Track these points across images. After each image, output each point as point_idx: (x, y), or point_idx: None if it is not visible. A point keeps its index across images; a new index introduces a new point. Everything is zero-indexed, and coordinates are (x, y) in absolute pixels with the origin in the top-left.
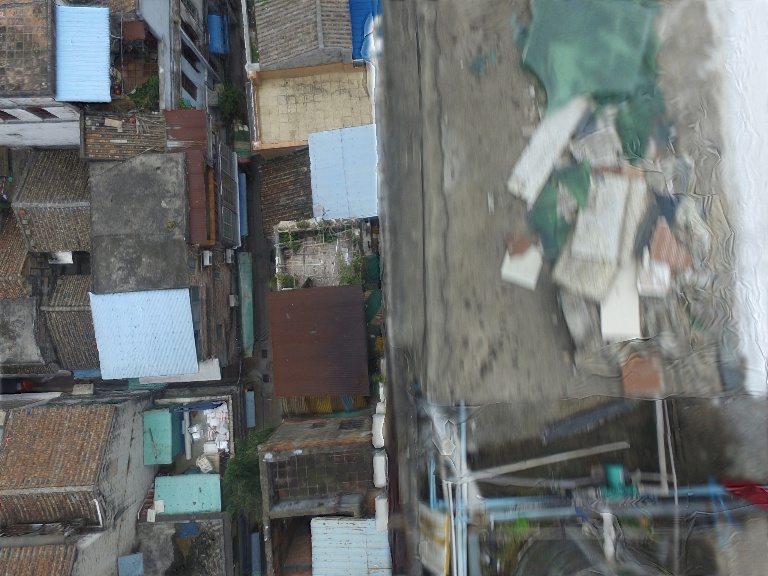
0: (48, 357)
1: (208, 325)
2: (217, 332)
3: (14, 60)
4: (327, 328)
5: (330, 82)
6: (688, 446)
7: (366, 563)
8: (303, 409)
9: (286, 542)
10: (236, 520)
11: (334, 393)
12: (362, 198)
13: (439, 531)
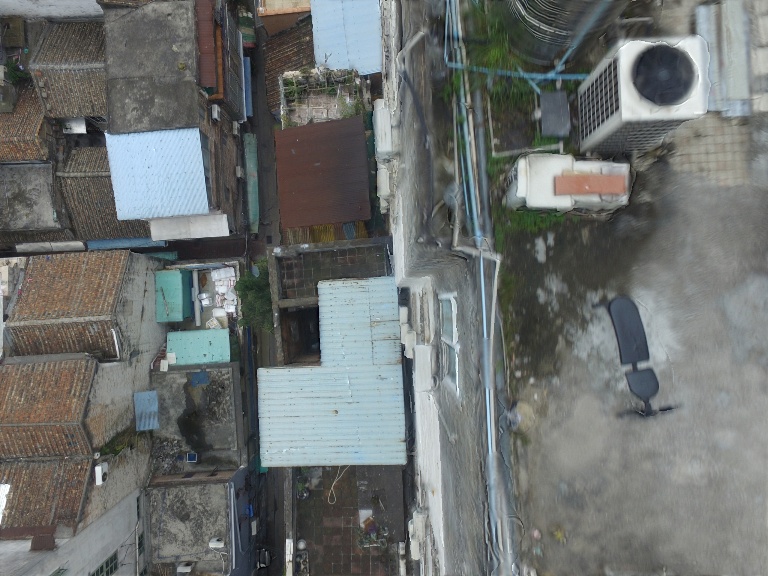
0: (64, 223)
1: (217, 178)
2: (225, 192)
3: None
4: (330, 159)
5: None
6: None
7: (369, 317)
8: None
9: (294, 349)
10: (244, 378)
11: (337, 220)
12: (362, 56)
13: None
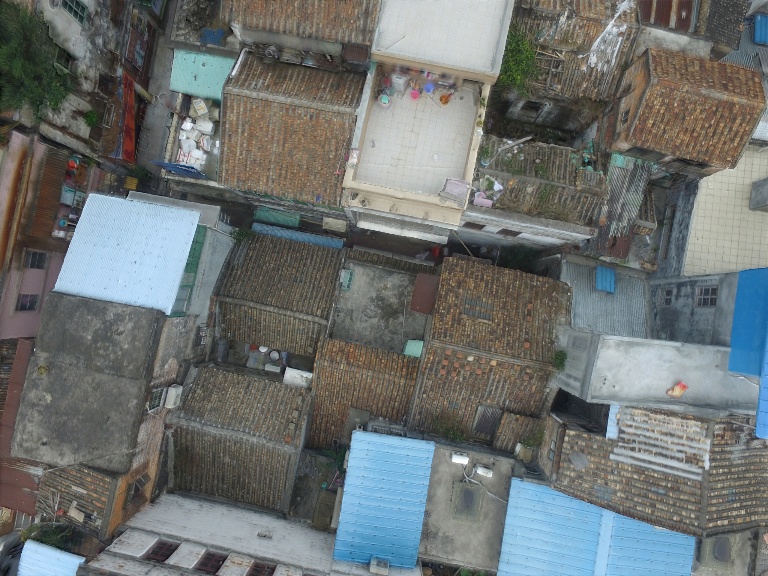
0: None
1: None
2: None
3: None
4: None
5: None
6: None
7: None
8: None
9: None
10: None
11: None
12: None
13: None
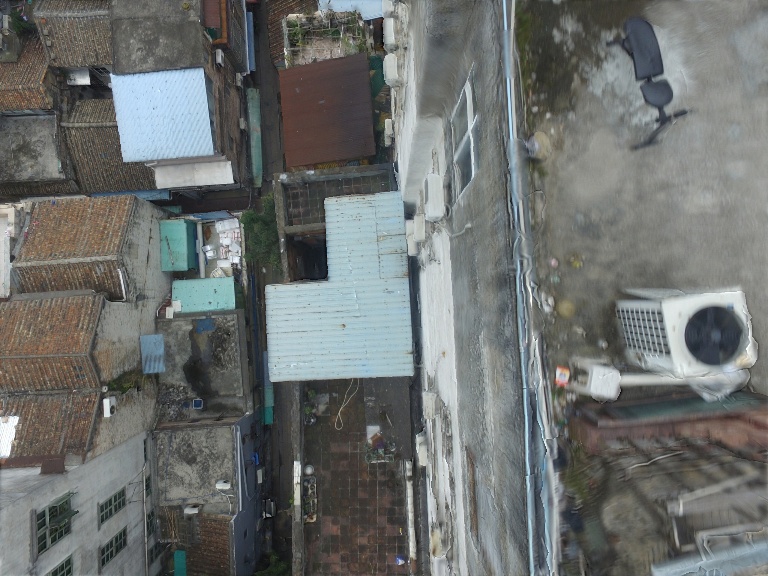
0: (68, 174)
1: (221, 124)
2: (229, 141)
3: None
4: (334, 97)
5: None
6: None
7: (375, 232)
8: None
9: None
10: (249, 328)
11: (342, 156)
12: (365, 1)
13: None
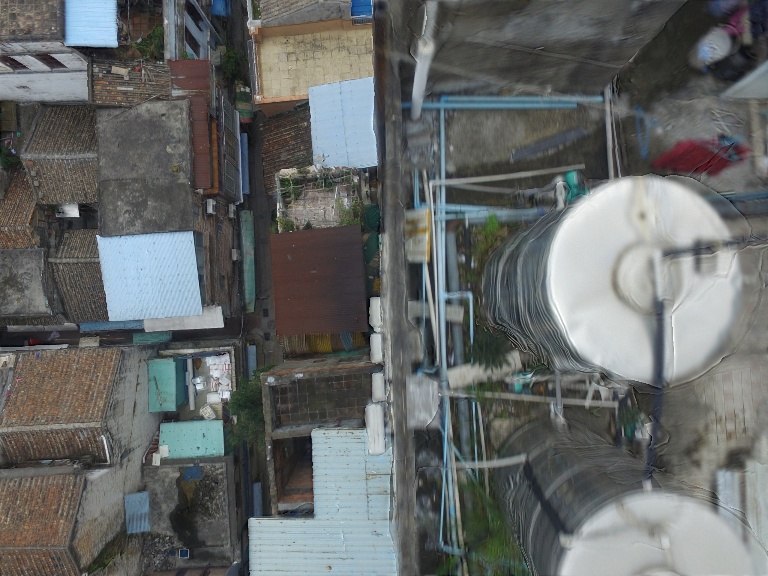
0: (55, 308)
1: (211, 272)
2: (220, 282)
3: (24, 6)
4: (327, 267)
5: (329, 40)
6: (634, 166)
7: (364, 470)
8: (304, 348)
9: (288, 469)
10: (239, 467)
11: (334, 330)
12: (361, 149)
13: (421, 222)
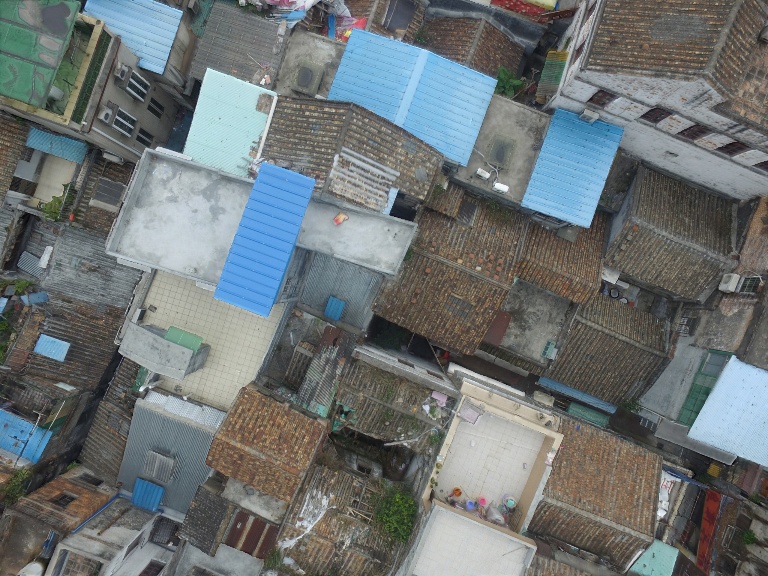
0: None
1: None
2: None
3: None
4: None
5: None
6: None
7: None
8: None
9: None
10: None
11: None
12: None
13: None
